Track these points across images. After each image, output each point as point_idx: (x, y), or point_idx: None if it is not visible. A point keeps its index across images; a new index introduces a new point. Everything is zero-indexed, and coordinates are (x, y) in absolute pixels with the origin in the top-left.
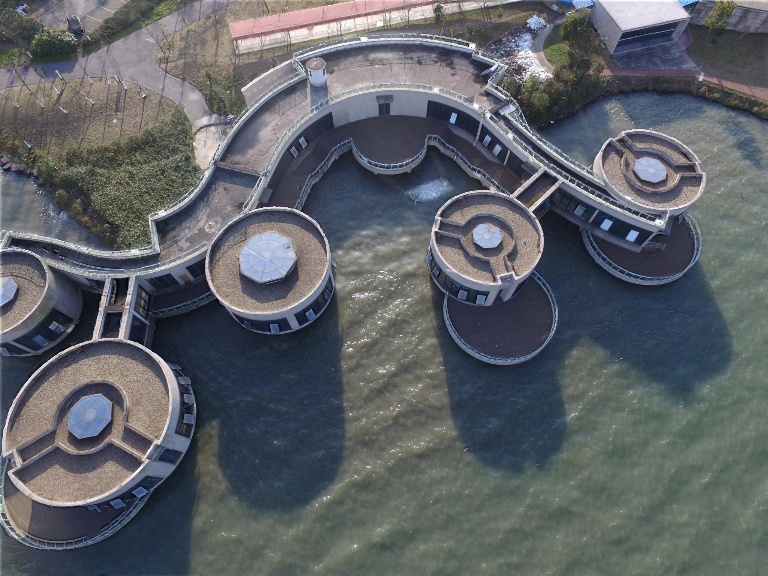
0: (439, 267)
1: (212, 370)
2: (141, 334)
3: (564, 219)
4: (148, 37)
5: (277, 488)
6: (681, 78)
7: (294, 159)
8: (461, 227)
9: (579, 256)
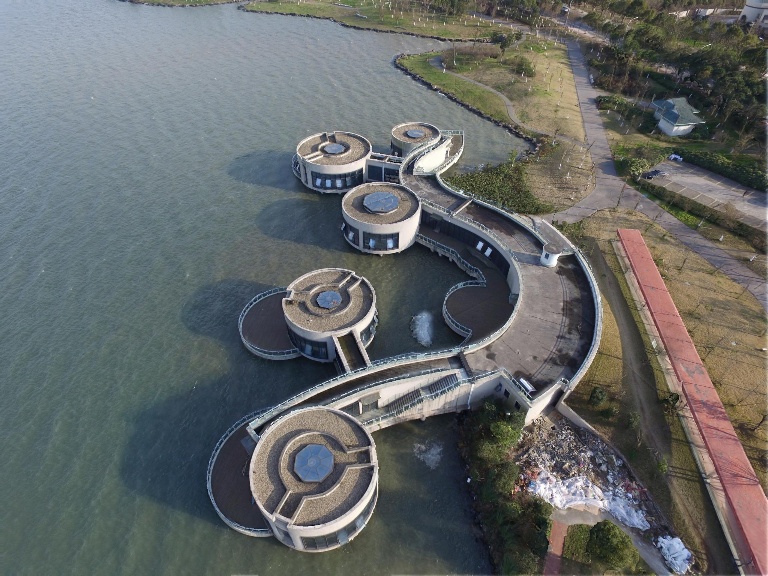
0: None
1: None
2: (376, 177)
3: None
4: (644, 206)
5: None
6: None
7: (479, 251)
8: None
9: None
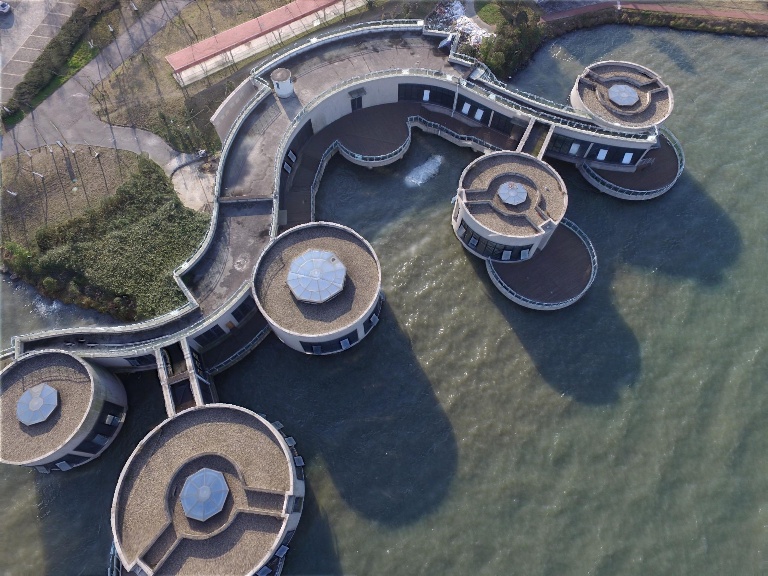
0: (478, 236)
1: (294, 407)
2: (208, 396)
3: (560, 161)
4: (74, 93)
5: (407, 496)
6: (603, 11)
7: (288, 176)
8: (485, 192)
9: (584, 190)
